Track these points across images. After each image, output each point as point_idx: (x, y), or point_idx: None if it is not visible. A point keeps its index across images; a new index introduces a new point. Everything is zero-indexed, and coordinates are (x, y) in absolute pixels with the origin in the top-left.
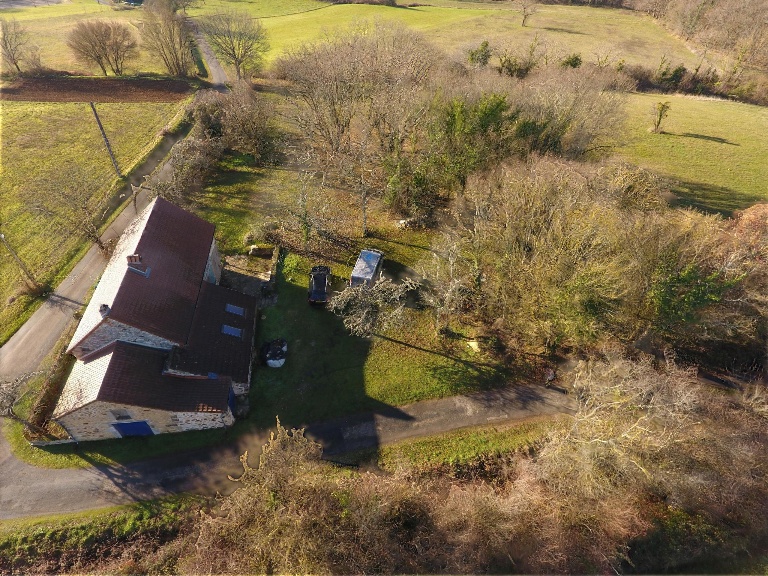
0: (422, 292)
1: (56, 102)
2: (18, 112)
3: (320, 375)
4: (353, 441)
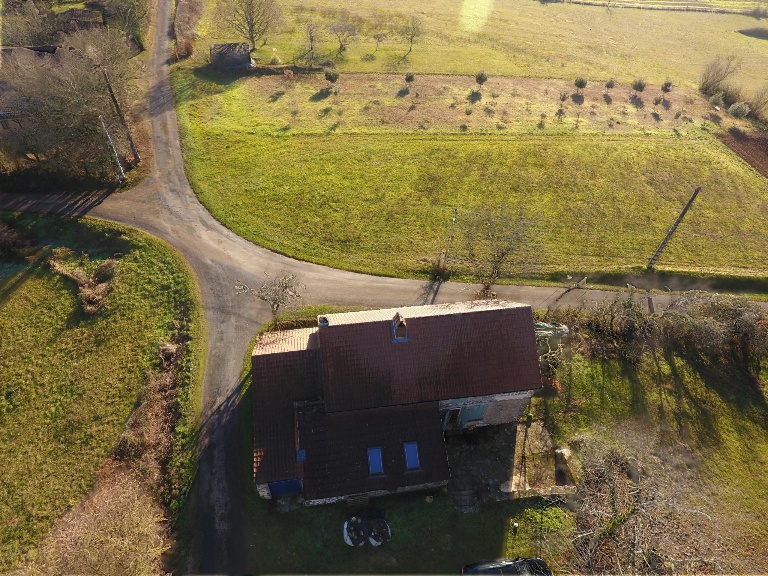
0: None
1: (756, 170)
2: (708, 155)
3: None
4: None
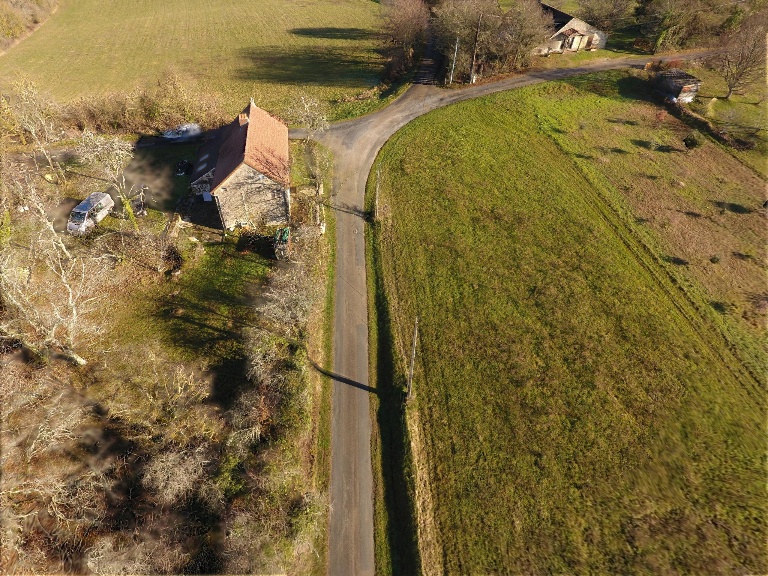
0: None
1: None
2: None
3: (158, 160)
4: (150, 142)
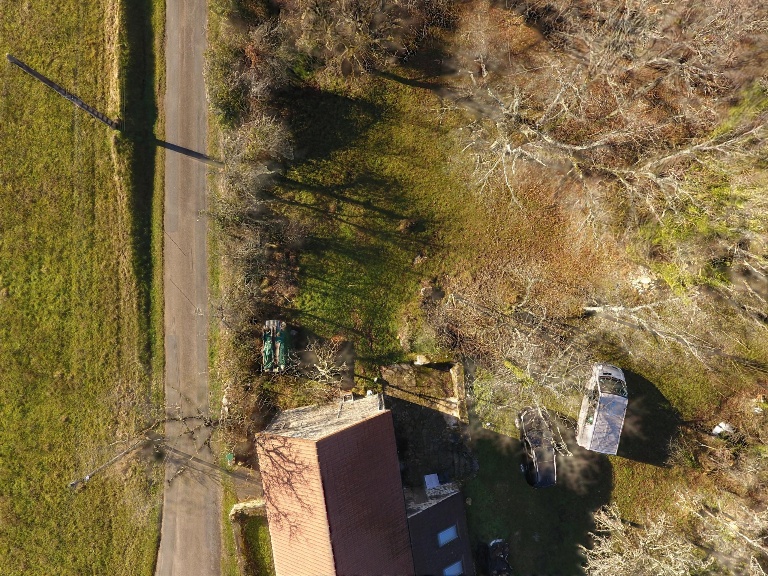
0: (674, 447)
1: None
2: None
3: None
4: None
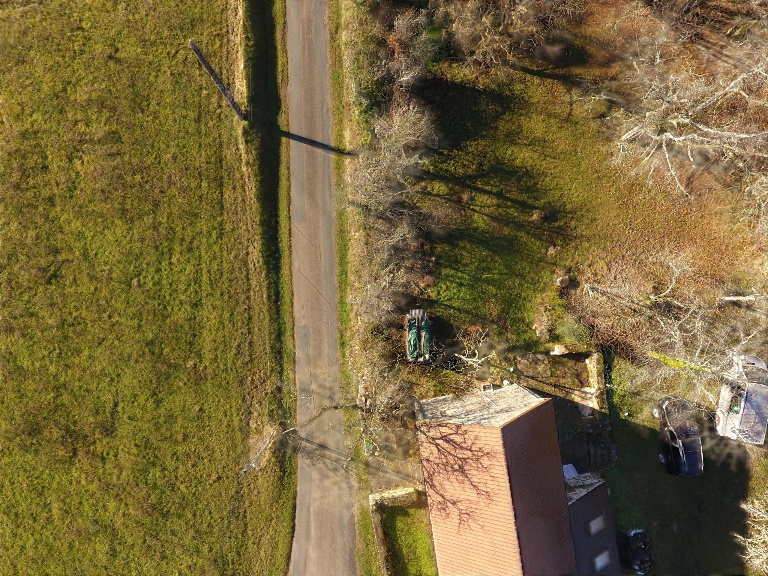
0: None
1: None
2: None
3: None
4: None
